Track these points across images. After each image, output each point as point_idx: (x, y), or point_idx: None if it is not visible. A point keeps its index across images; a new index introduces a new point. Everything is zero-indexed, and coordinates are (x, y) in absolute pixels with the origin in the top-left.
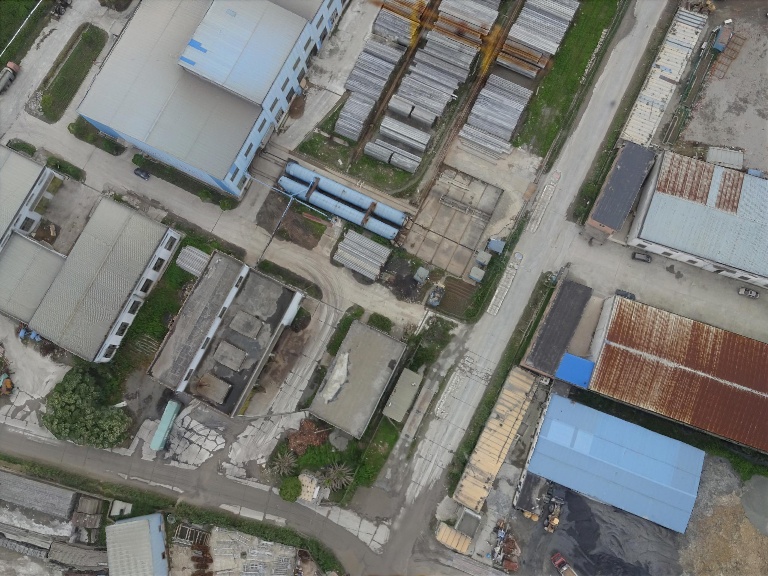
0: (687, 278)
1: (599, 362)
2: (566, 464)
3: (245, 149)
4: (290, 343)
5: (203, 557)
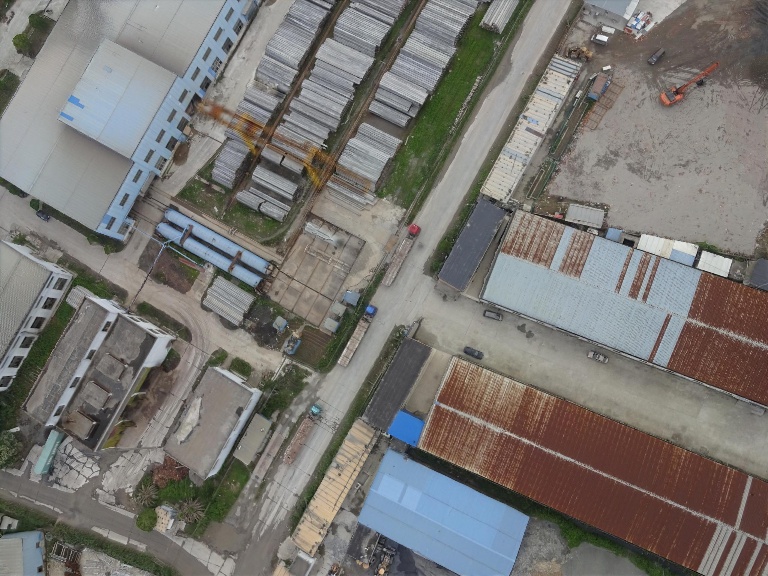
0: (537, 338)
1: (429, 422)
2: (393, 518)
3: (119, 200)
4: (160, 382)
5: (73, 573)
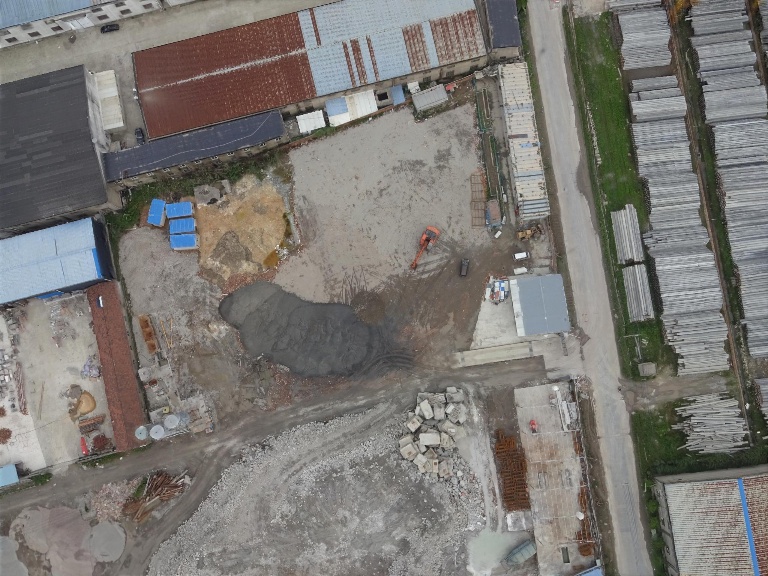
0: None
1: None
2: None
3: None
4: None
5: None
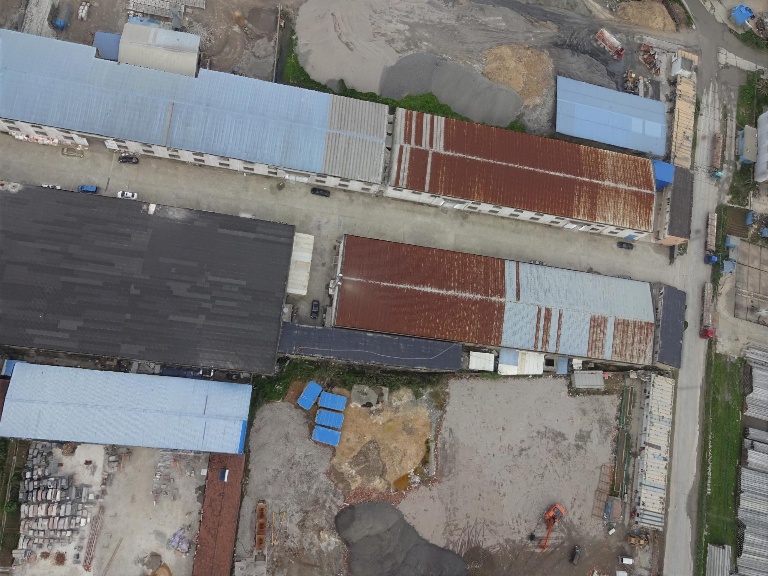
0: (584, 269)
1: (653, 178)
2: (643, 110)
3: None
4: None
5: None
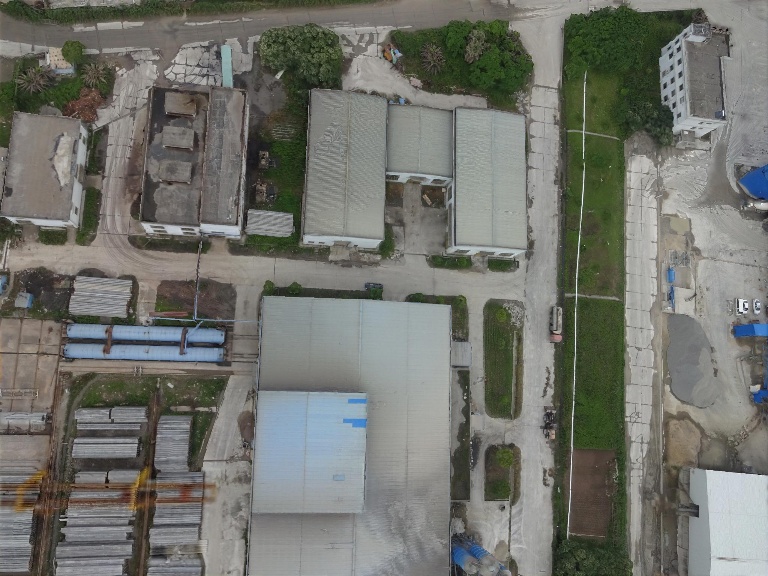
0: None
1: None
2: None
3: None
4: None
5: None
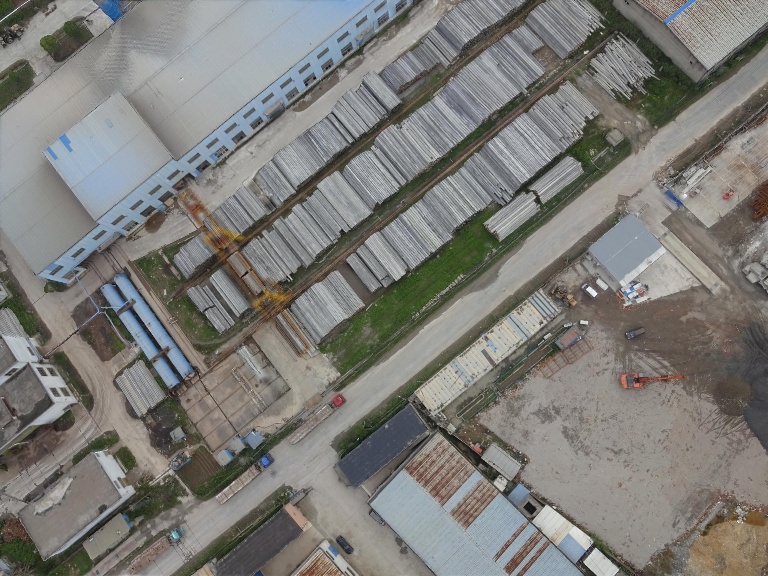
0: (410, 557)
1: None
2: None
3: (72, 252)
4: (47, 438)
5: None
